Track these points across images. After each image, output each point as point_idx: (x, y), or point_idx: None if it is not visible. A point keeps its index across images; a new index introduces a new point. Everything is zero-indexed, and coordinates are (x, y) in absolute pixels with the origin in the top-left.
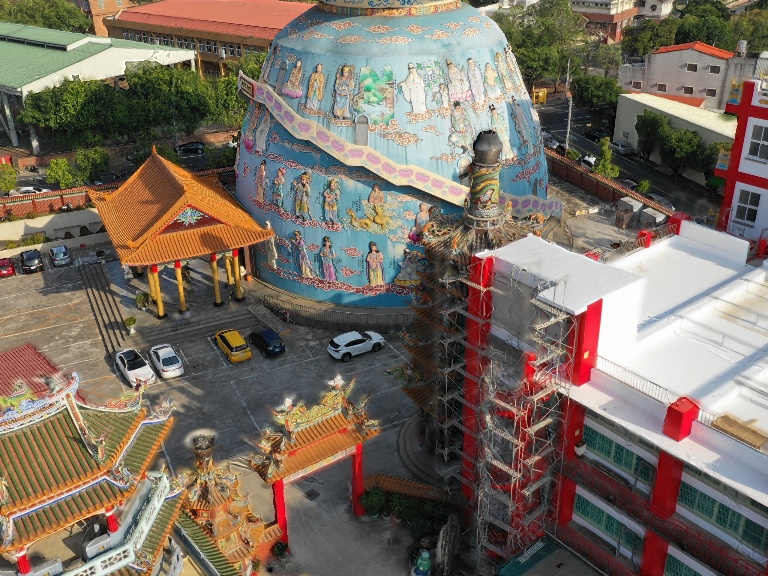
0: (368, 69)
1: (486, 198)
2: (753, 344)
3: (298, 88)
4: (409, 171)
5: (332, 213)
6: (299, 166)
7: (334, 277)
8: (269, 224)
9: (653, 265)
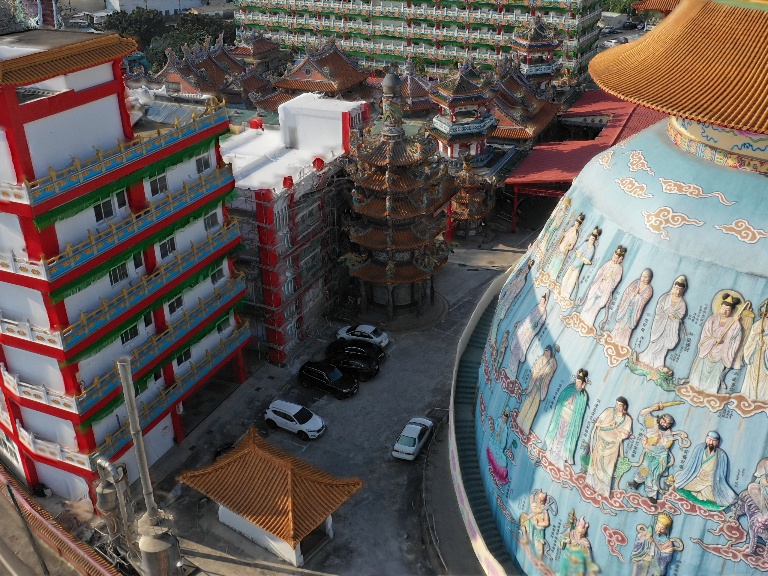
0: None
1: None
2: None
3: None
4: None
5: None
6: None
7: None
8: None
9: (280, 189)
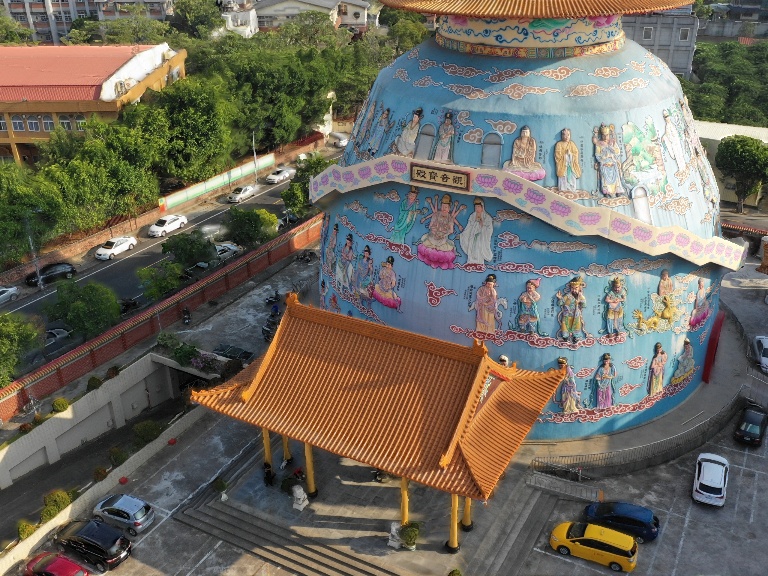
0: (631, 126)
1: None
2: None
3: (537, 166)
4: (712, 245)
5: (617, 322)
6: (565, 271)
7: (610, 401)
8: (507, 359)
9: None
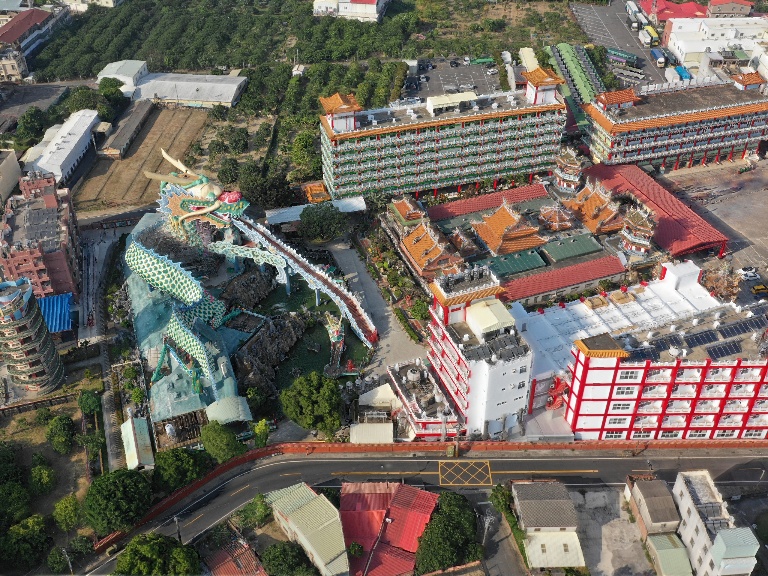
0: None
1: None
2: (674, 308)
3: None
4: None
5: None
6: None
7: None
8: None
9: None
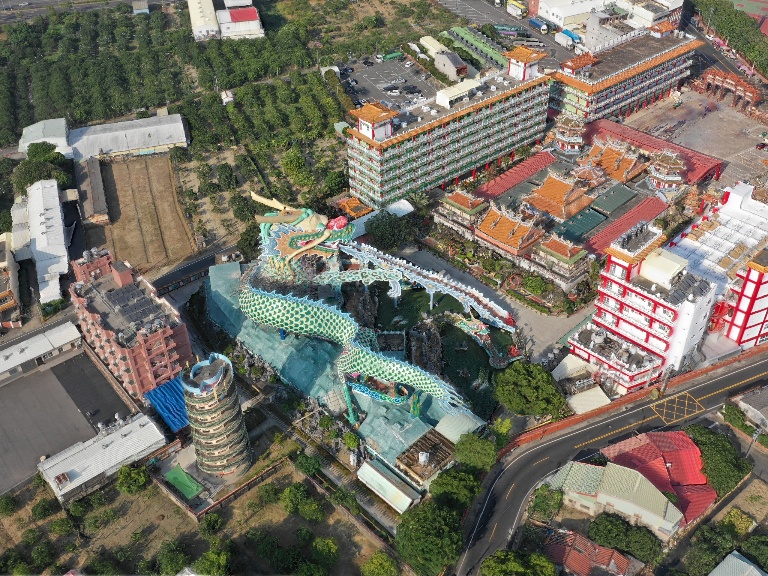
0: None
1: (767, 180)
2: (751, 223)
3: None
4: None
5: None
6: None
7: None
8: None
9: None
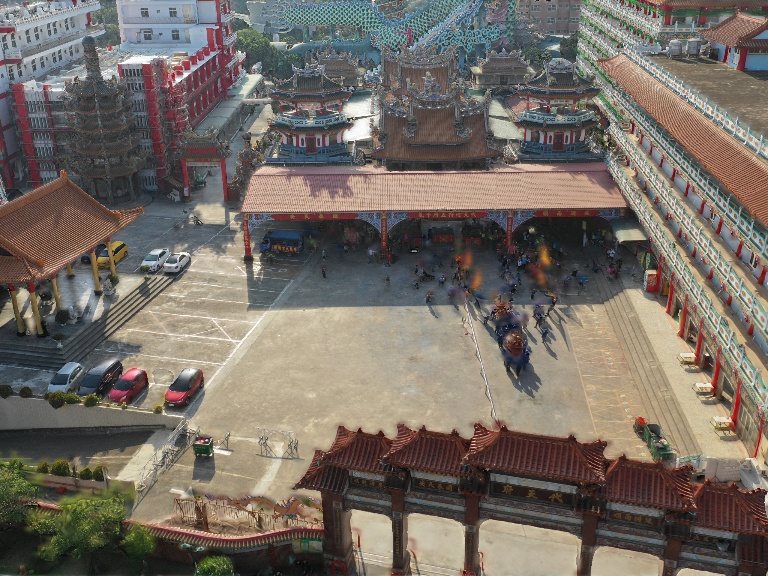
0: None
1: None
2: None
3: None
4: None
5: None
6: None
7: None
8: None
9: None
